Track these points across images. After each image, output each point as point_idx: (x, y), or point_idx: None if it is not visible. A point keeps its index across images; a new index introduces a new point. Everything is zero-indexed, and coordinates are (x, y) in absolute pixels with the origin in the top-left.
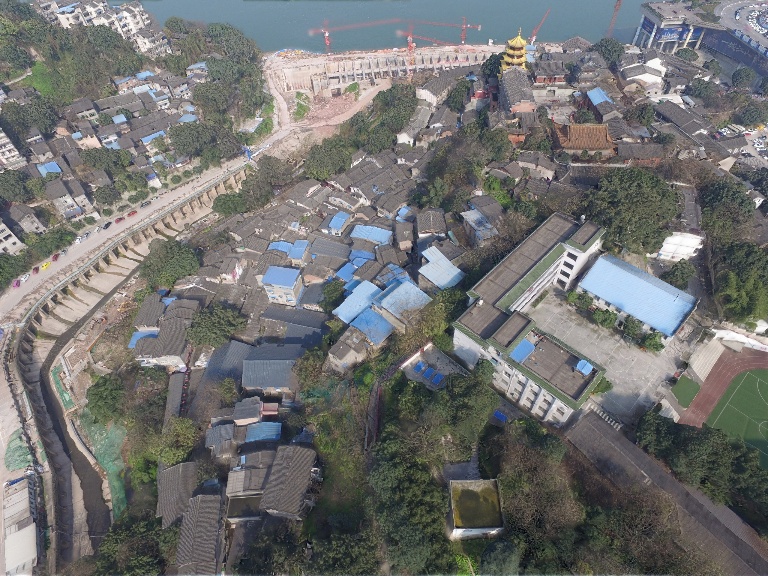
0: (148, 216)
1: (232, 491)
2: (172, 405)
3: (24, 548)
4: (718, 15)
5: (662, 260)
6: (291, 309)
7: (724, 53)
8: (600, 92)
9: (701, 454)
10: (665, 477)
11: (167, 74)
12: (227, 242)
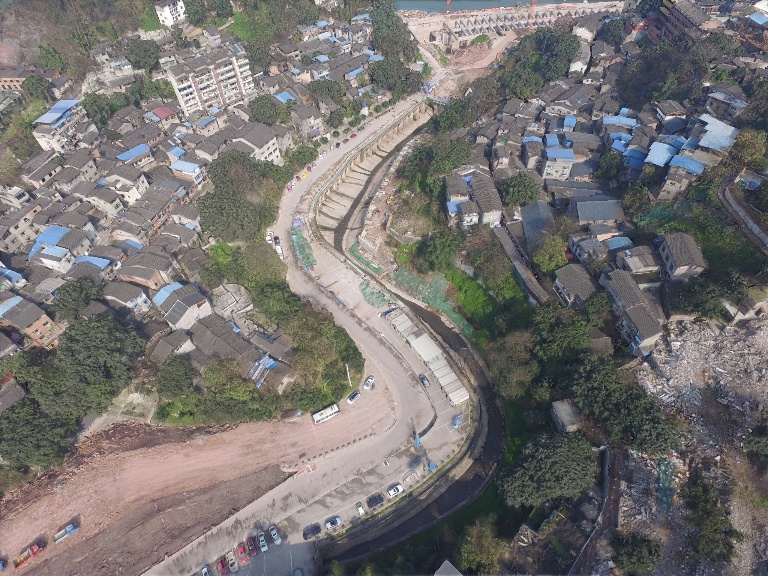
0: (368, 137)
1: (636, 268)
2: (509, 245)
3: (429, 347)
4: None
5: None
6: (565, 181)
7: None
8: (762, 14)
9: None
10: None
11: (343, 23)
12: (472, 144)
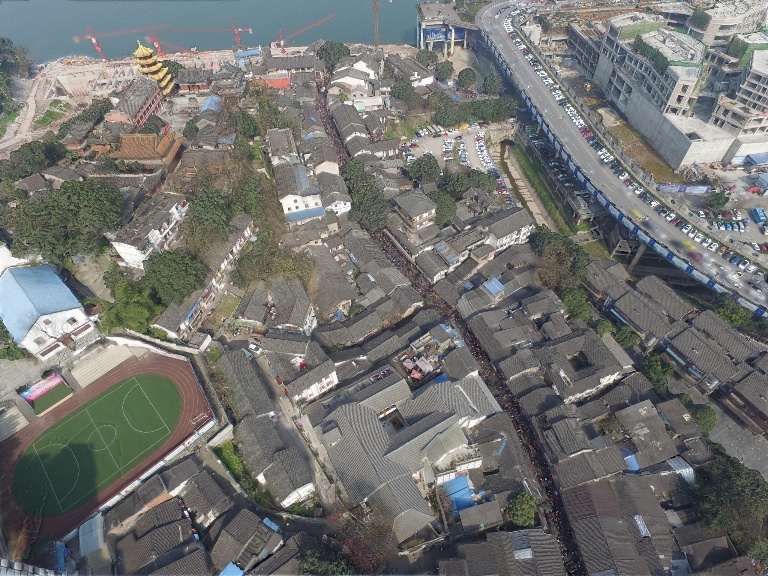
0: None
1: None
2: None
3: None
4: (480, 14)
5: (133, 268)
6: None
7: (481, 52)
8: (210, 100)
9: None
10: None
11: None
12: None
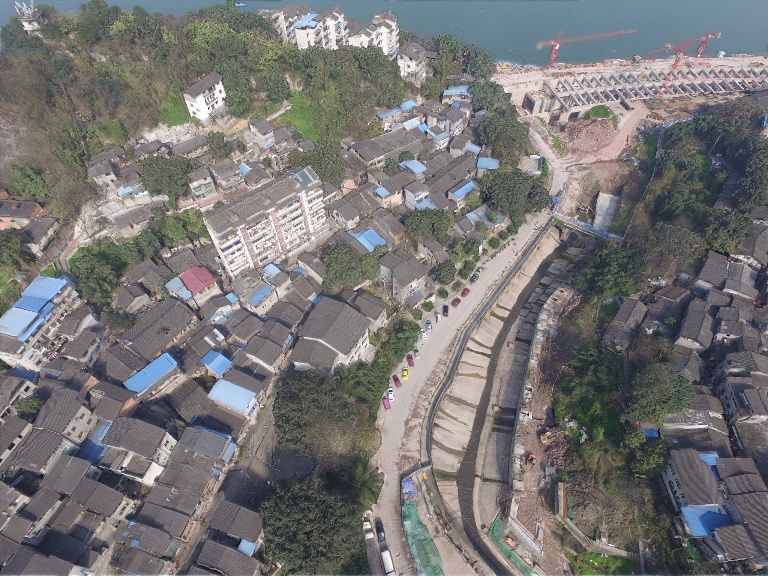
0: (486, 295)
1: None
2: None
3: None
4: None
5: None
6: None
7: None
8: None
9: None
10: None
11: (437, 104)
12: (672, 348)
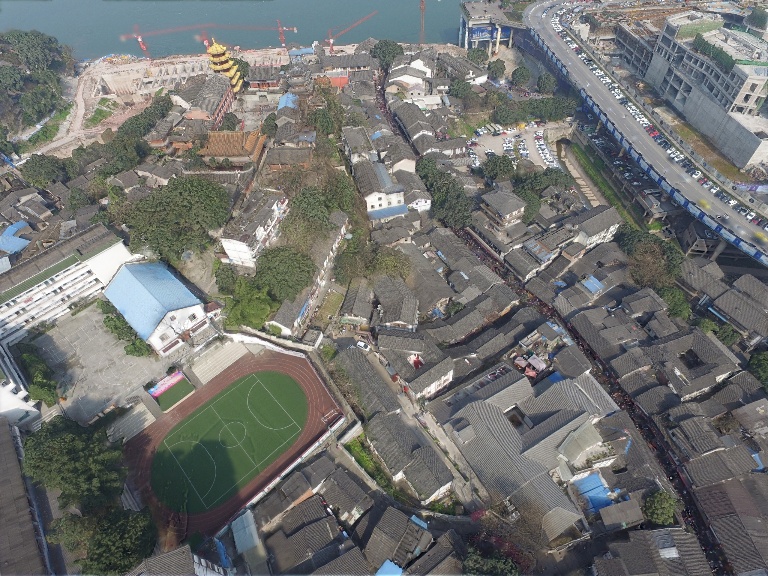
0: None
1: None
2: None
3: None
4: (526, 14)
5: (236, 265)
6: None
7: (528, 51)
8: (287, 97)
9: (27, 459)
10: (11, 481)
11: None
12: None
